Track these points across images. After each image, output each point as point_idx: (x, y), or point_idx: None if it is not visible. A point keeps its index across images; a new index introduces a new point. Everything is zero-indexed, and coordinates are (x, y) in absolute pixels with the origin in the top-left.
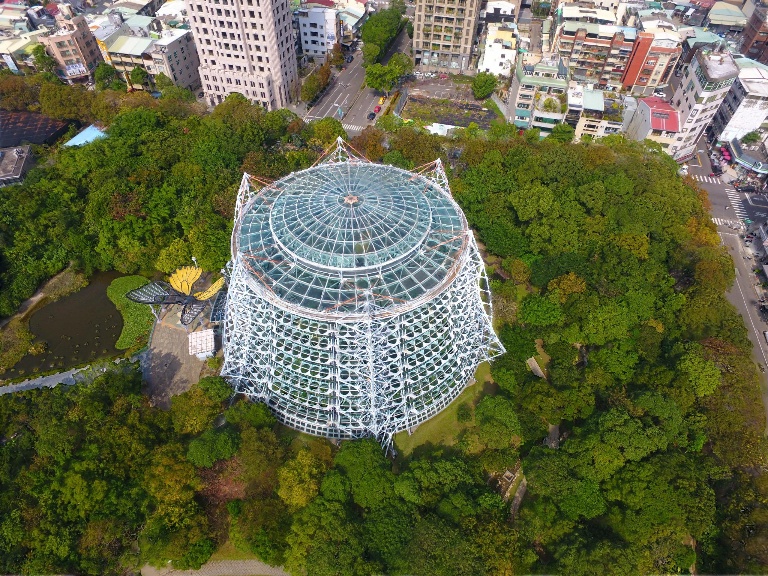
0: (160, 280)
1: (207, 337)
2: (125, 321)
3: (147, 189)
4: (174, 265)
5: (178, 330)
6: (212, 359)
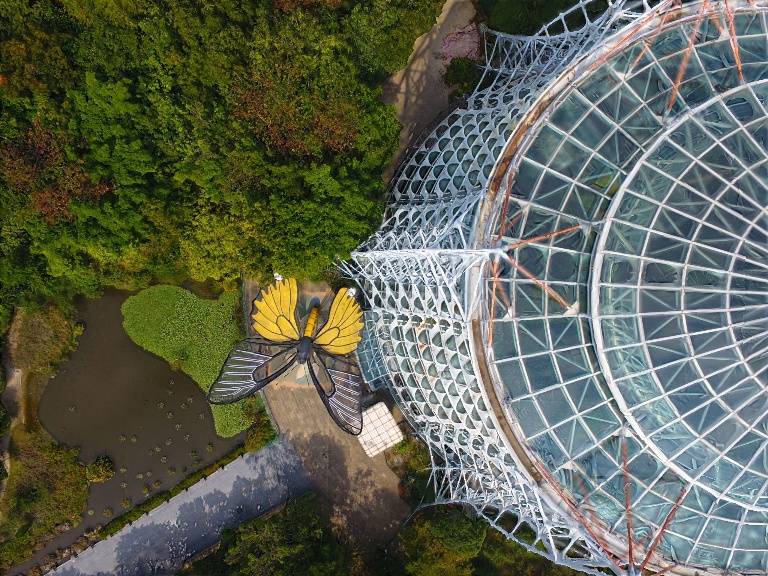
0: (209, 291)
1: (382, 420)
2: (202, 385)
3: (57, 105)
4: (227, 269)
5: (306, 390)
6: (414, 462)
